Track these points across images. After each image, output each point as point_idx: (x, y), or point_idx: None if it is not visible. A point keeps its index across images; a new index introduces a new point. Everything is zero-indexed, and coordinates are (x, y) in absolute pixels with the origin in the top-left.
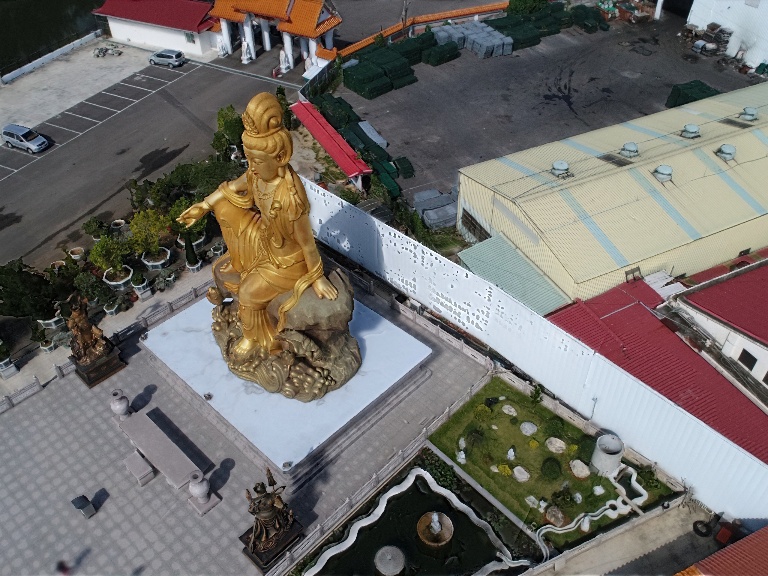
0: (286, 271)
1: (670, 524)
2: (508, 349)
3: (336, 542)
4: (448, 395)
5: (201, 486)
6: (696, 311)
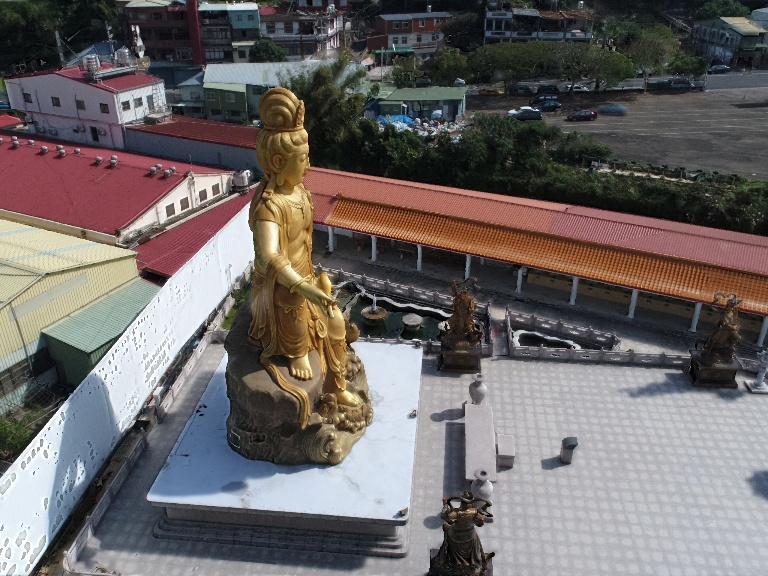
0: None
1: None
2: None
3: None
4: None
5: None
6: None
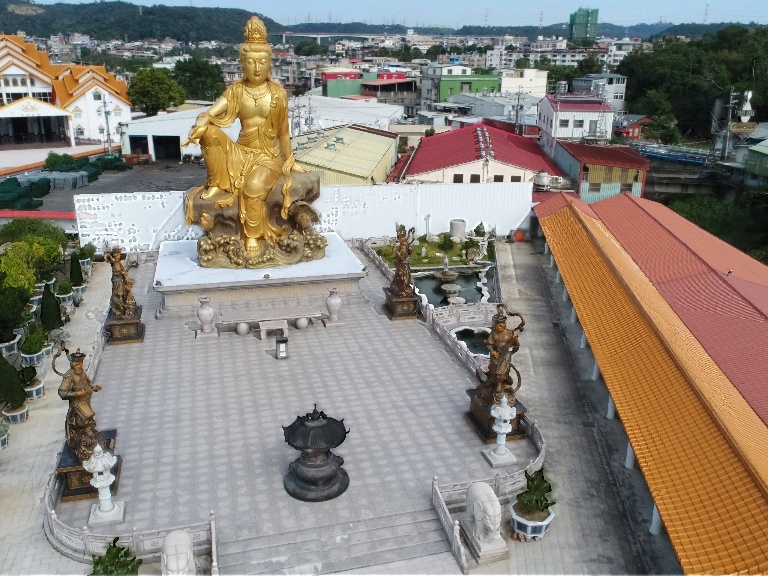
0: (277, 160)
1: (501, 245)
2: (358, 231)
3: None
4: None
5: (338, 297)
6: (420, 174)
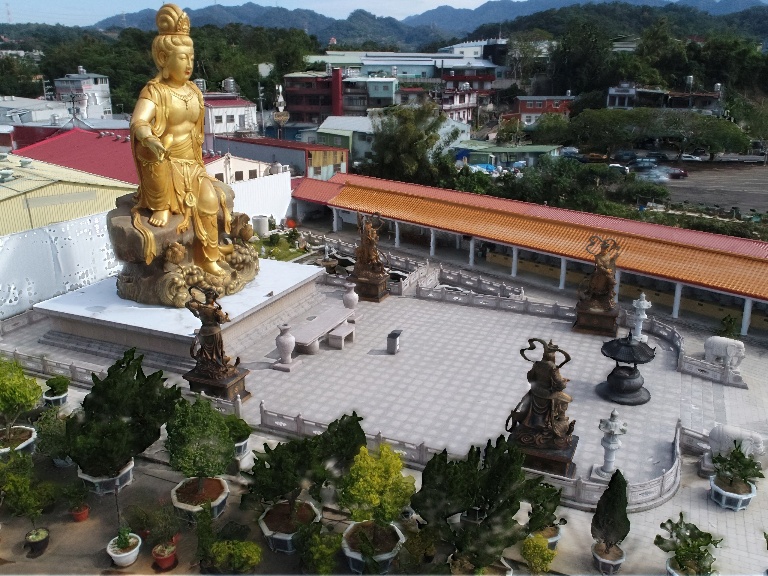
0: None
1: None
2: None
3: None
4: None
5: None
6: None
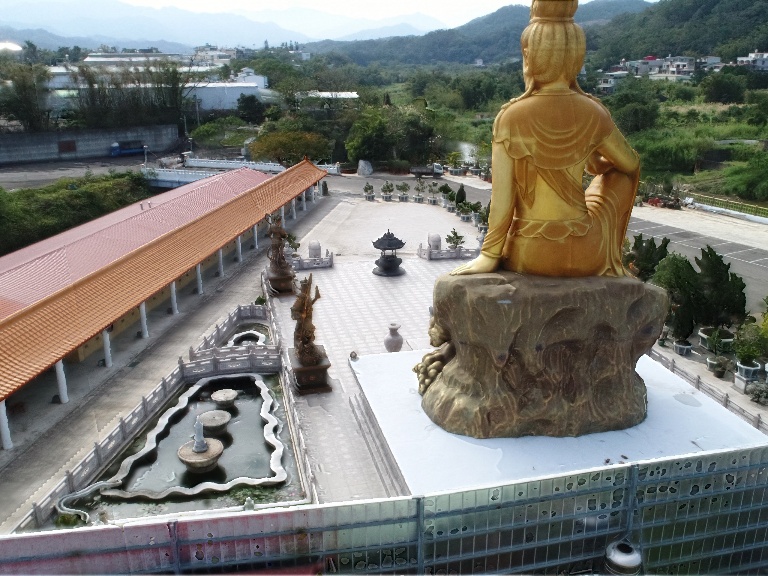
0: None
1: None
2: None
3: (276, 411)
4: (360, 554)
5: None
6: None
